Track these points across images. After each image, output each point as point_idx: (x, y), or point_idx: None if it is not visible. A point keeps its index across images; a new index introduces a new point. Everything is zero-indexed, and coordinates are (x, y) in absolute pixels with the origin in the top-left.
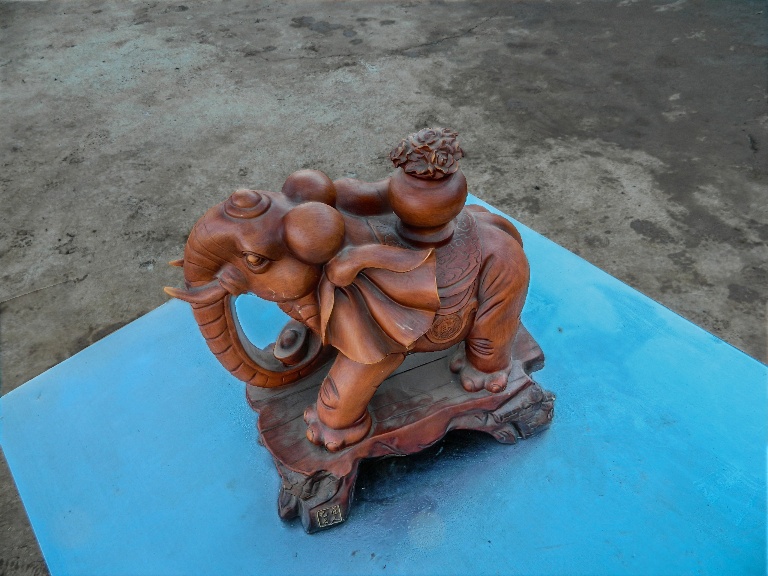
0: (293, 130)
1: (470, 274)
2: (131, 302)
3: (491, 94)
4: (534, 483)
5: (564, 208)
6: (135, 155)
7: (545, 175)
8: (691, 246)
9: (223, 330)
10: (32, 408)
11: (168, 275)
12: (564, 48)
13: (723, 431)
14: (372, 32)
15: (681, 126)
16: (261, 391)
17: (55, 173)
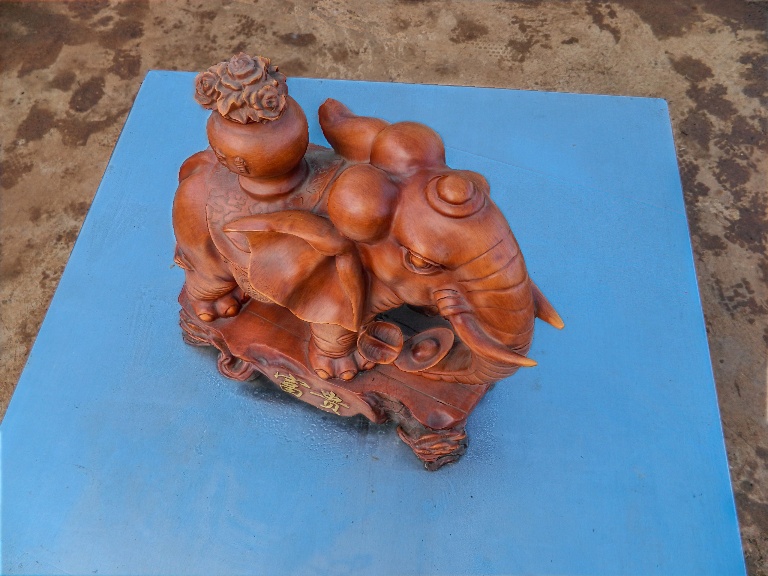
0: None
1: None
2: None
3: None
4: None
5: None
6: None
7: None
8: None
9: None
10: None
11: None
12: None
13: None
14: None
15: None
16: None
17: None
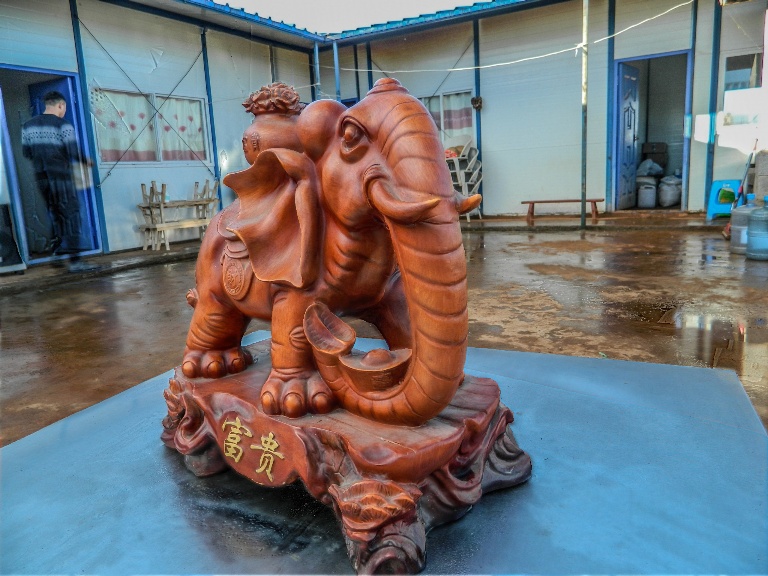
0: None
1: None
2: None
3: None
4: None
5: None
6: None
7: None
8: None
9: None
10: None
11: None
12: None
13: None
14: None
15: None
16: (439, 428)
17: None
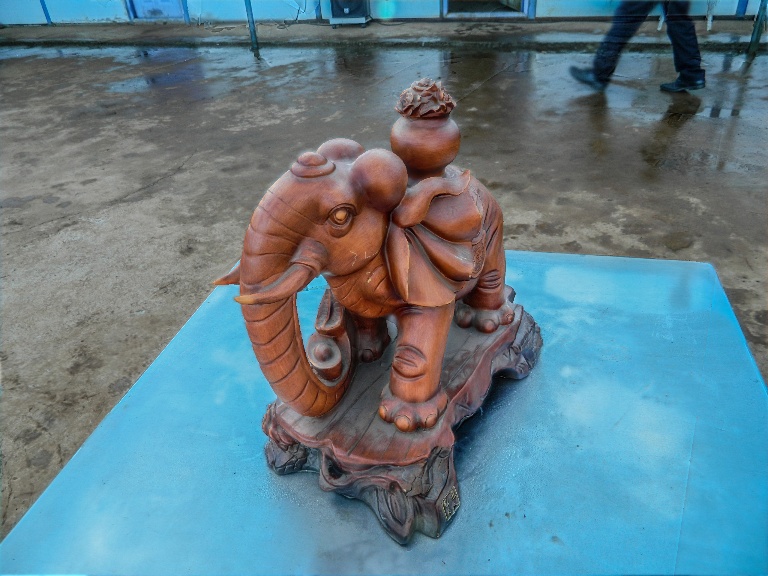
0: (41, 298)
1: (477, 205)
2: None
3: (235, 208)
4: (567, 391)
5: None
6: None
7: None
8: None
9: (292, 339)
10: None
11: None
12: (273, 161)
13: (637, 299)
14: (77, 193)
15: None
16: (313, 425)
17: None
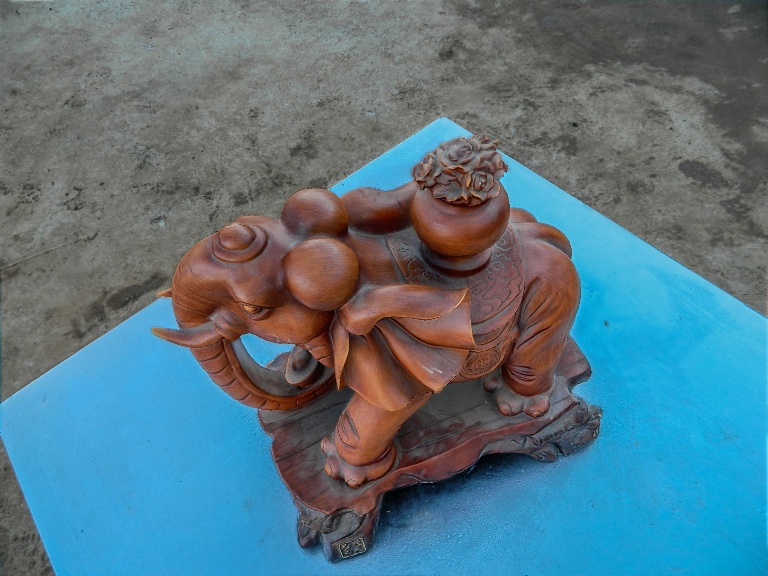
0: (306, 62)
1: (511, 304)
2: (144, 263)
3: (524, 12)
4: (576, 509)
5: (604, 148)
6: (139, 96)
7: (584, 109)
8: (747, 191)
9: (225, 365)
10: (38, 413)
11: (180, 232)
12: None
13: None
14: None
15: (741, 45)
16: (274, 412)
17: (57, 119)
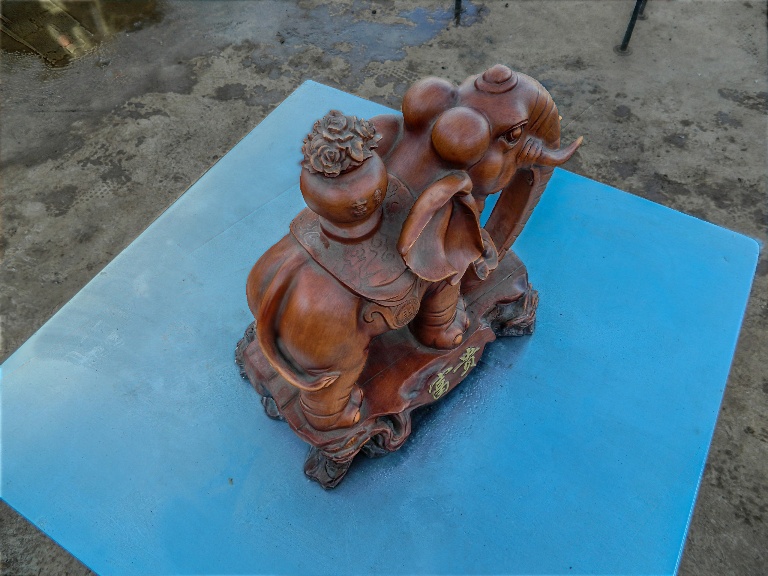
0: None
1: None
2: None
3: None
4: None
5: None
6: None
7: None
8: None
9: None
10: (717, 248)
11: None
12: None
13: (81, 397)
14: None
15: None
16: None
17: None
